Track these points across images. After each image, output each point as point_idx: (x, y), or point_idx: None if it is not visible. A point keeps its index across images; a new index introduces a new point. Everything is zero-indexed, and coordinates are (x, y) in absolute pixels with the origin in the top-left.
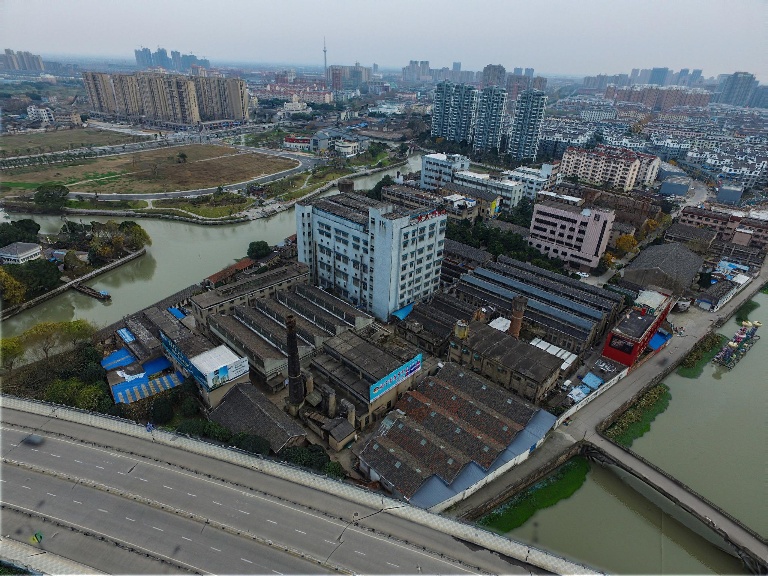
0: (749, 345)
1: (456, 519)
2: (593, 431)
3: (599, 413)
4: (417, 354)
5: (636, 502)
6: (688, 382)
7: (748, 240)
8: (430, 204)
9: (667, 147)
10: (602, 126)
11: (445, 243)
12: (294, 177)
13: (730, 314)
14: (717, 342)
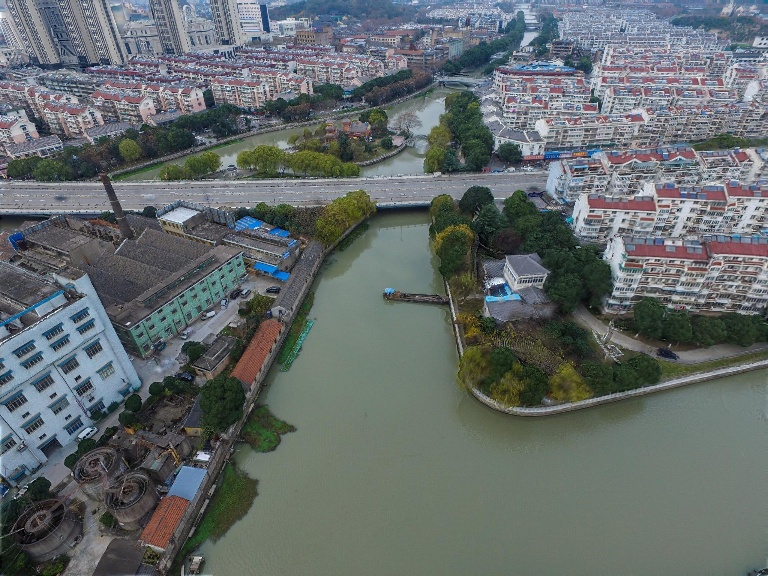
0: None
1: None
2: None
3: None
4: None
5: None
6: None
7: None
8: None
9: None
10: None
11: None
12: None
13: None
14: None
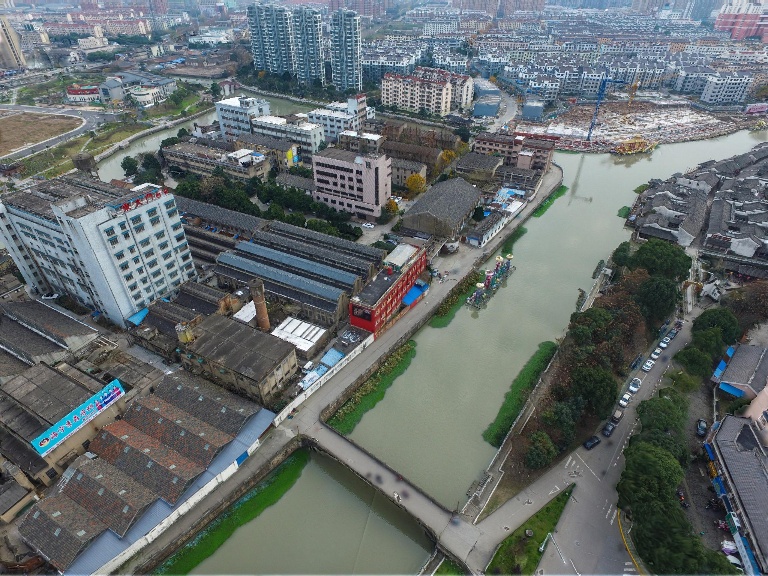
0: (503, 278)
1: (134, 571)
2: (316, 419)
3: (330, 394)
4: (138, 370)
5: (351, 484)
6: (436, 333)
7: (529, 162)
8: (215, 164)
9: (489, 62)
10: (432, 43)
11: (217, 214)
12: (67, 143)
13: (496, 247)
14: (475, 281)
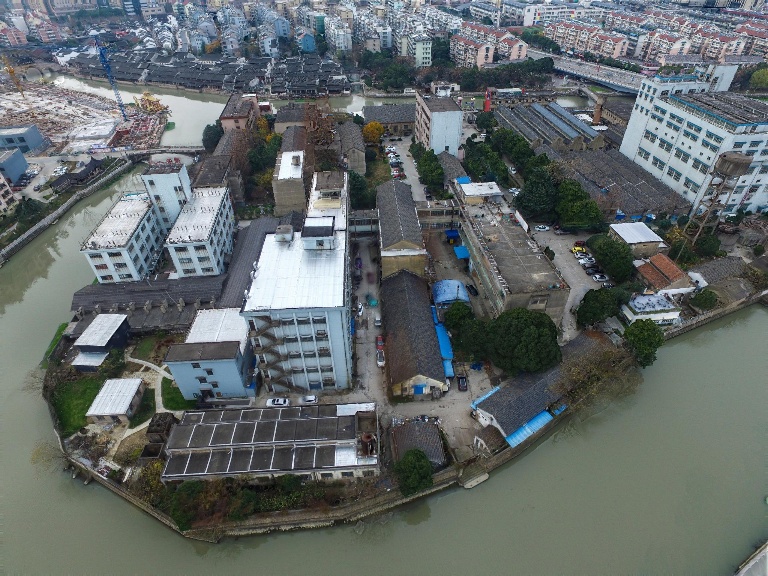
0: None
1: None
2: None
3: None
4: None
5: None
6: None
7: None
8: None
9: None
10: None
11: None
12: None
13: None
14: None
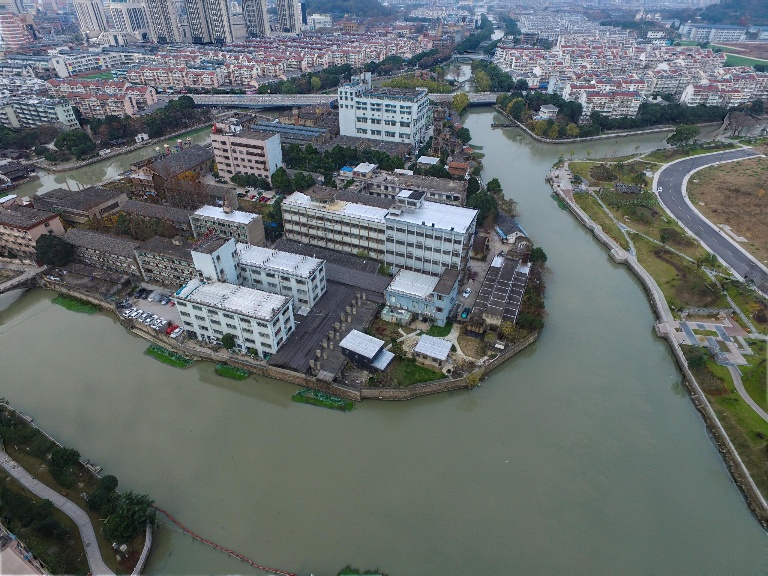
0: None
1: None
2: None
3: None
4: None
5: None
6: None
7: None
8: None
9: None
10: None
11: None
12: (679, 236)
13: None
14: None
